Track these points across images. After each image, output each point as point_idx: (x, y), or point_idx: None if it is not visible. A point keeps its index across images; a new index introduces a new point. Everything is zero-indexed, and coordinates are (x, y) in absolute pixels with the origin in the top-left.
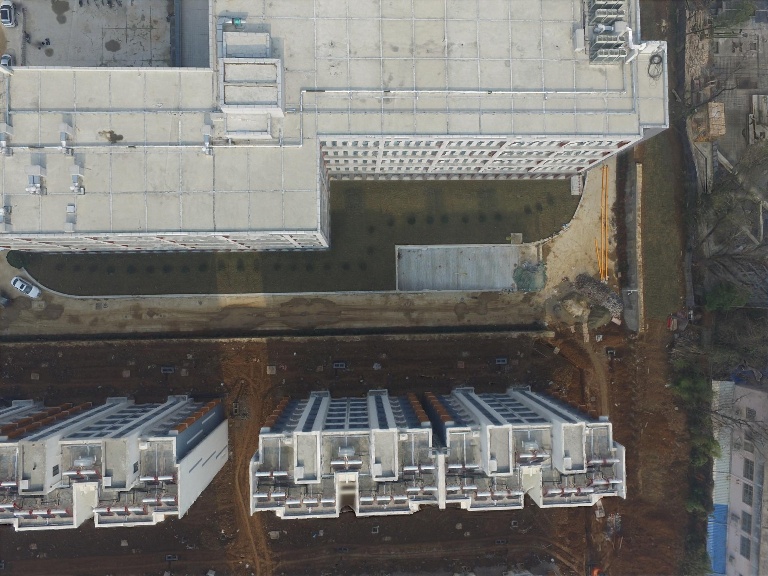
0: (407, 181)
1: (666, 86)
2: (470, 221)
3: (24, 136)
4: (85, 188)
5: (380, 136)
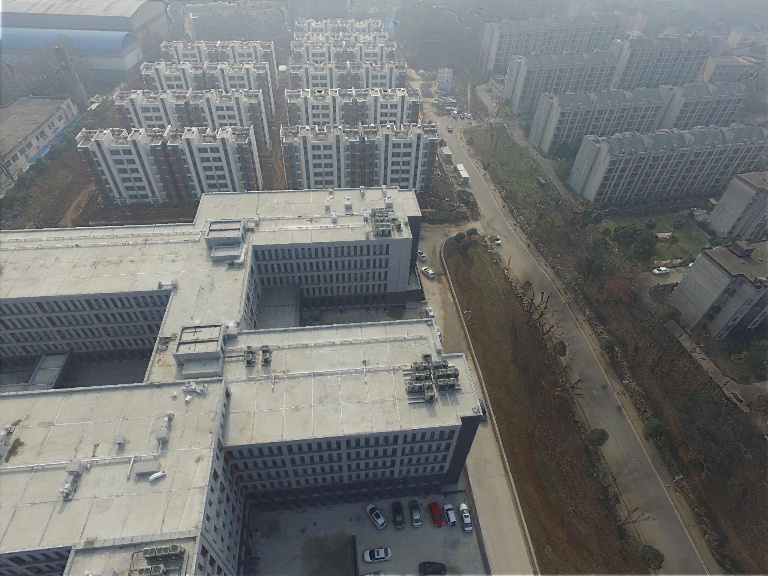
0: None
1: None
2: None
3: None
4: None
5: (156, 225)
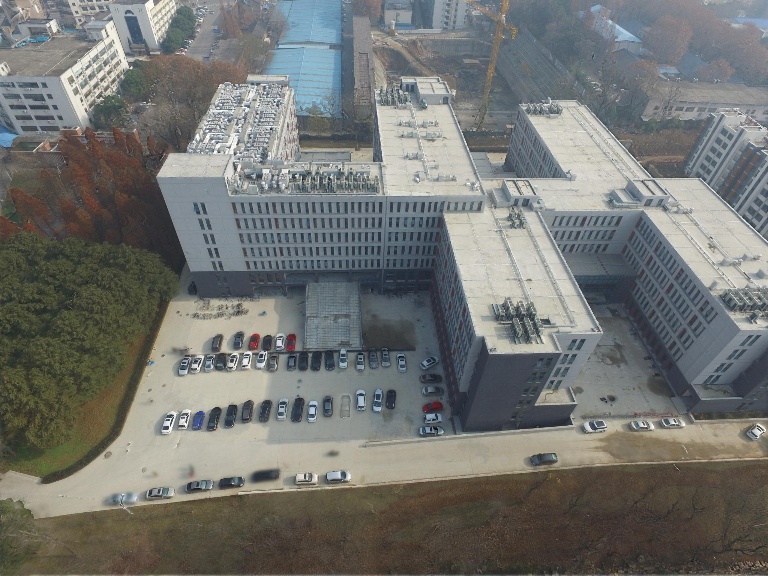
0: None
1: None
2: None
3: (745, 283)
4: None
5: None
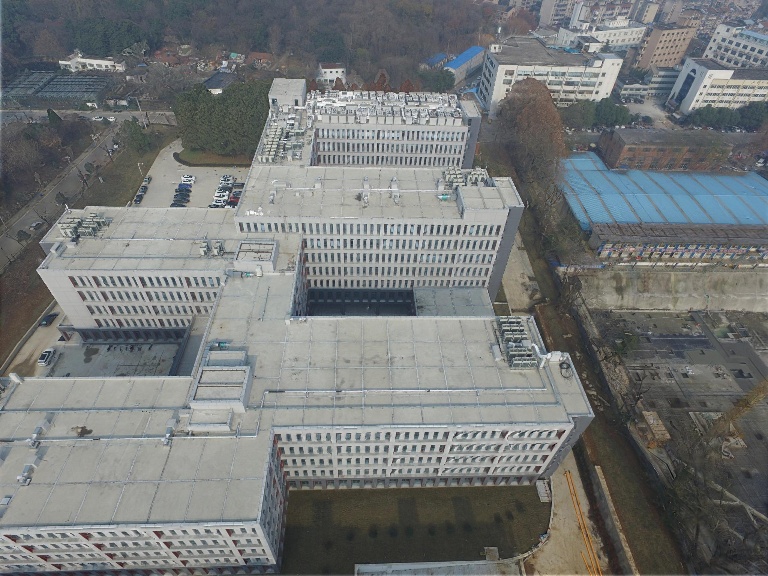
0: (369, 490)
1: (580, 384)
2: (437, 533)
3: (1, 432)
4: (32, 479)
5: (330, 427)
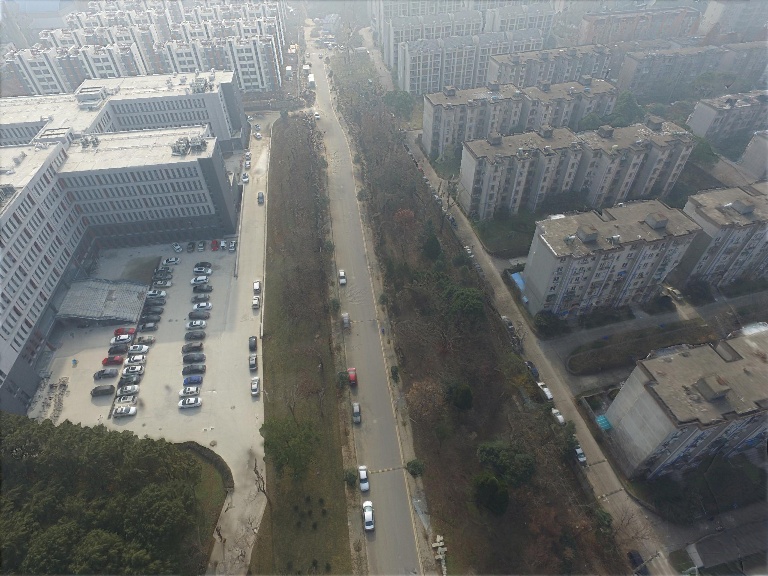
0: None
1: None
2: None
3: None
4: None
5: (49, 95)
